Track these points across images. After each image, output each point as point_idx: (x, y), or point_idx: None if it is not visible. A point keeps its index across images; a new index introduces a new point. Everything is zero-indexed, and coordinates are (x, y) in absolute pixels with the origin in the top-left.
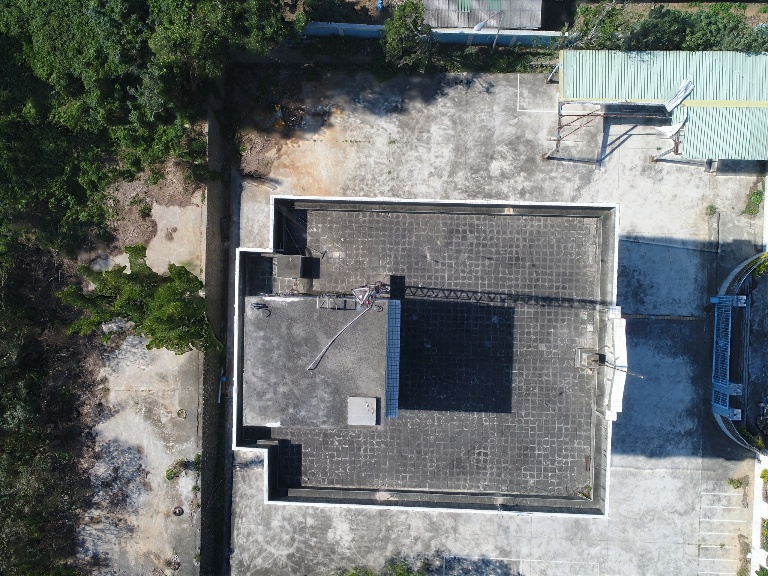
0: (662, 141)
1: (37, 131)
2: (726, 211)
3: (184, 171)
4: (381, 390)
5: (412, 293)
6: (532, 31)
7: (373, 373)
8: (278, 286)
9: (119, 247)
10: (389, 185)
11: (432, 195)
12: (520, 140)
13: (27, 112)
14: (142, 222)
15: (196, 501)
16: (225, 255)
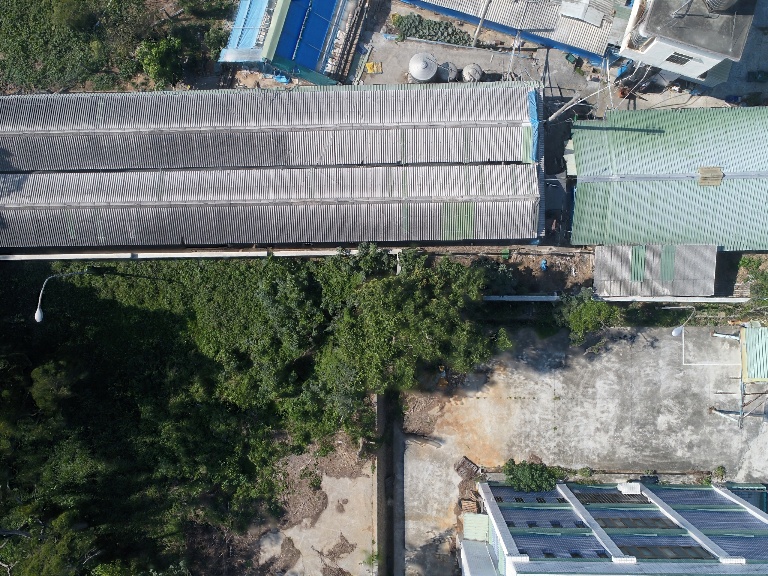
0: None
1: (203, 406)
2: None
3: (356, 446)
4: None
5: None
6: (705, 298)
7: None
8: None
9: (289, 520)
10: (555, 441)
11: (599, 450)
12: (686, 394)
13: (195, 391)
14: (312, 495)
15: None
16: (388, 512)
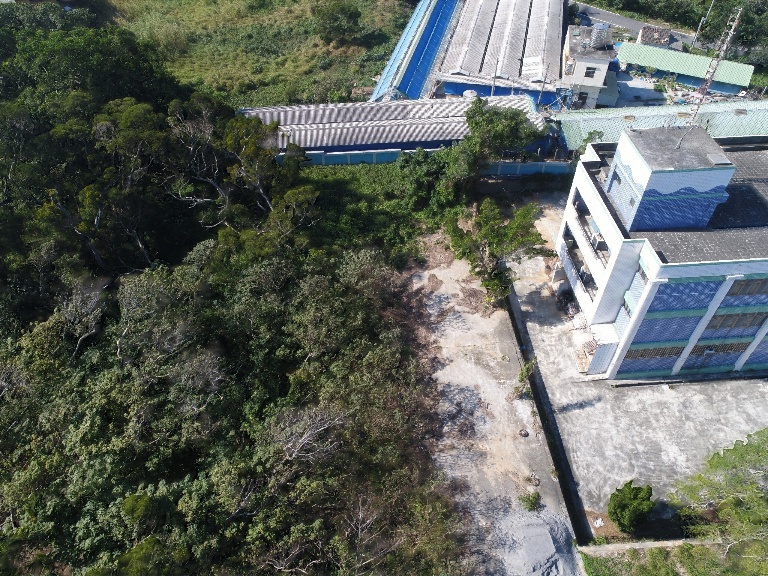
0: None
1: None
2: None
3: None
4: None
5: None
6: None
7: (713, 147)
8: (604, 185)
9: (431, 265)
10: None
11: None
12: None
13: (362, 205)
14: (445, 252)
15: (537, 424)
16: None
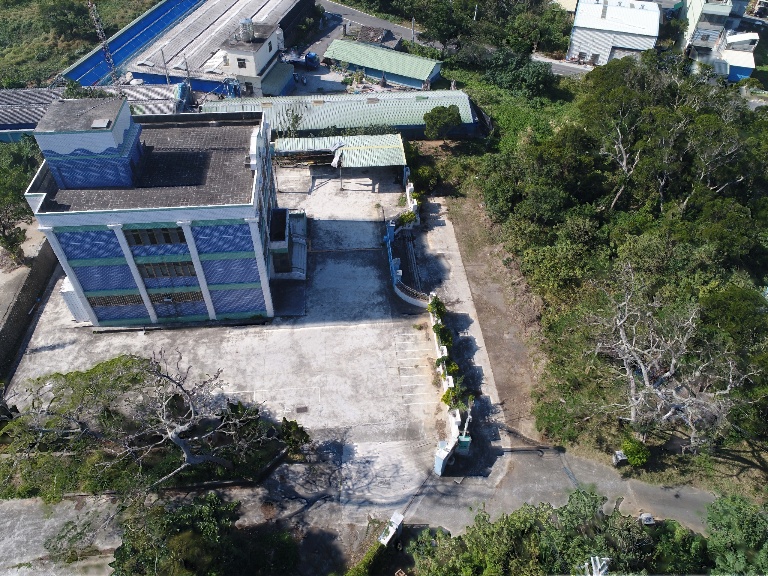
0: (346, 183)
1: None
2: (387, 206)
3: None
4: (113, 119)
5: (157, 150)
6: None
7: None
8: None
9: None
10: None
11: None
12: None
13: None
14: None
15: None
16: None
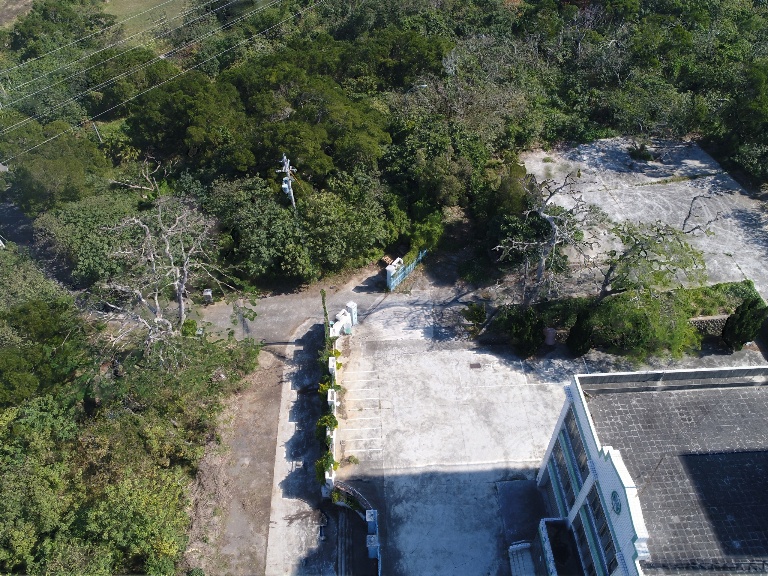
0: None
1: None
2: None
3: None
4: None
5: None
6: None
7: None
8: None
9: None
10: None
11: None
12: None
13: None
14: None
15: None
16: None
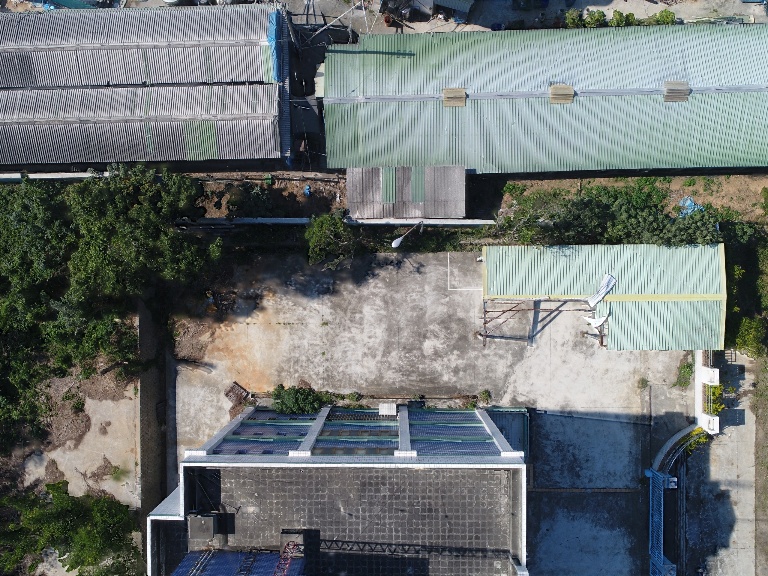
0: None
1: None
2: (658, 384)
3: (115, 368)
4: None
5: (327, 546)
6: (457, 220)
7: None
8: (194, 542)
9: (53, 443)
10: (323, 366)
11: (366, 375)
12: (452, 319)
13: None
14: (75, 417)
15: None
16: (163, 438)
